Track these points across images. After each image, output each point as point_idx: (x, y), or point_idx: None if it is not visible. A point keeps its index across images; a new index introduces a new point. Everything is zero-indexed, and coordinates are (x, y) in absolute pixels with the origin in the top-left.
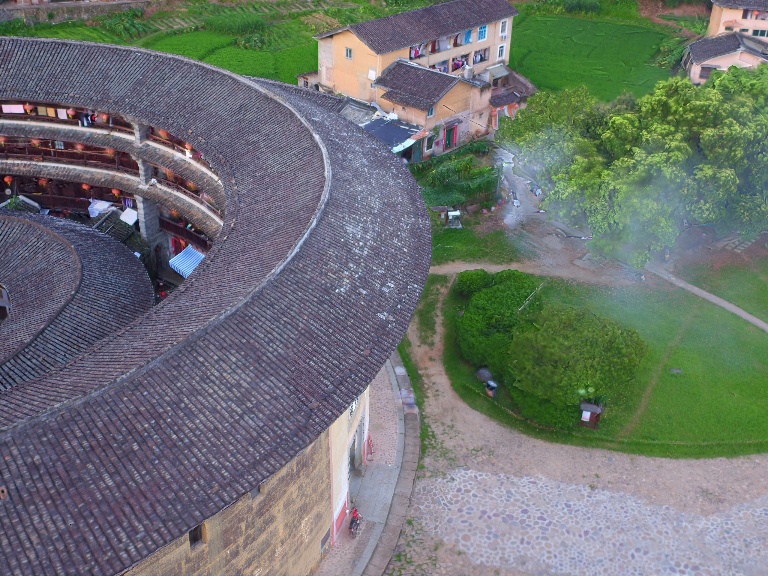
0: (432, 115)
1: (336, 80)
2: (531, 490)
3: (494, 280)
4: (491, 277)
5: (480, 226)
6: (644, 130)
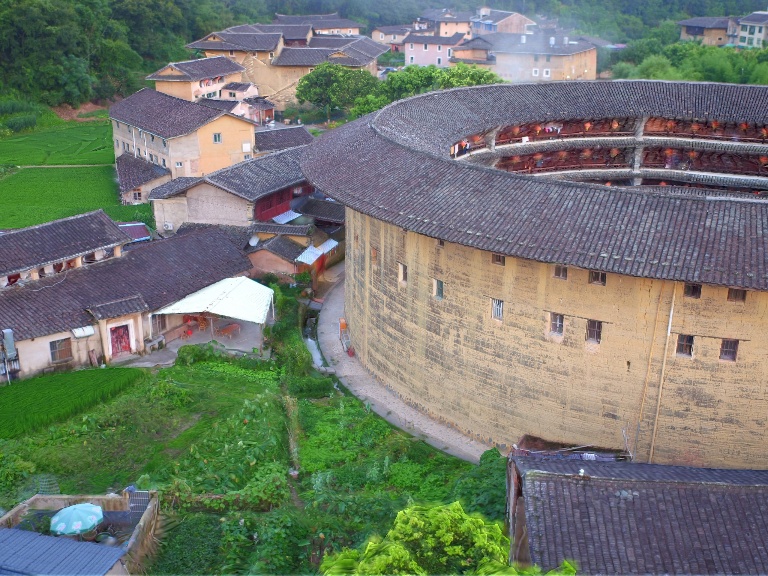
0: None
1: (205, 168)
2: None
3: None
4: None
5: None
6: None
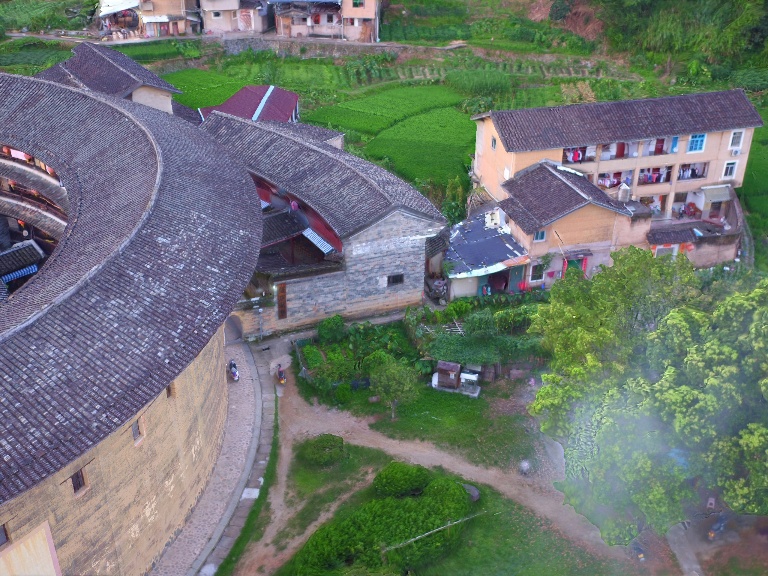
0: (543, 239)
1: (483, 170)
2: None
3: (423, 488)
4: (427, 482)
5: (505, 401)
6: (695, 345)
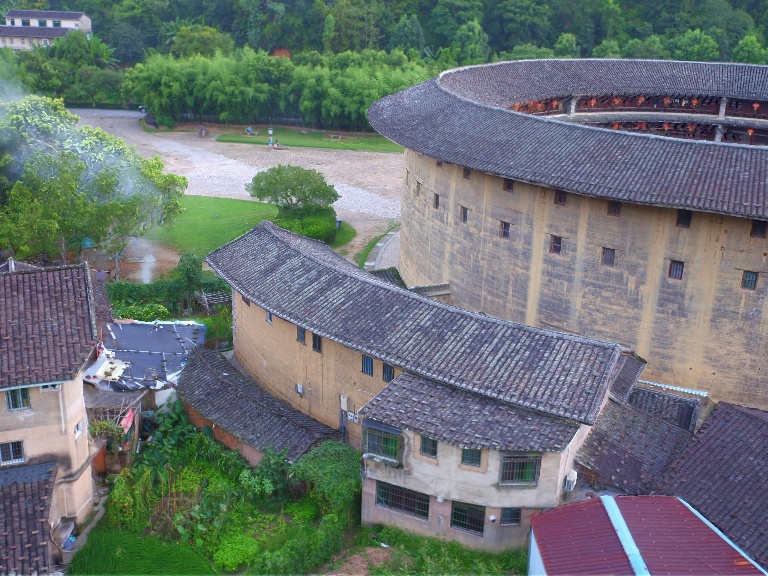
0: None
1: None
2: None
3: None
4: None
5: None
6: None
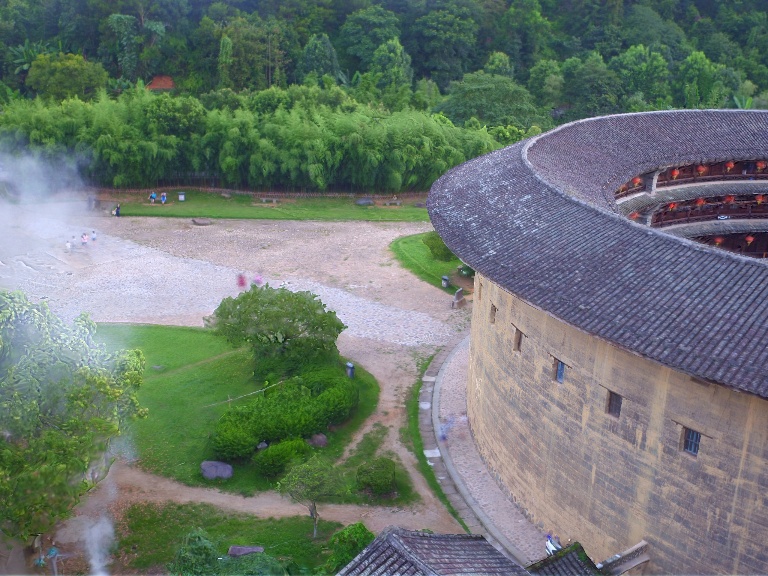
0: None
1: None
2: (365, 331)
3: None
4: (257, 452)
5: None
6: None
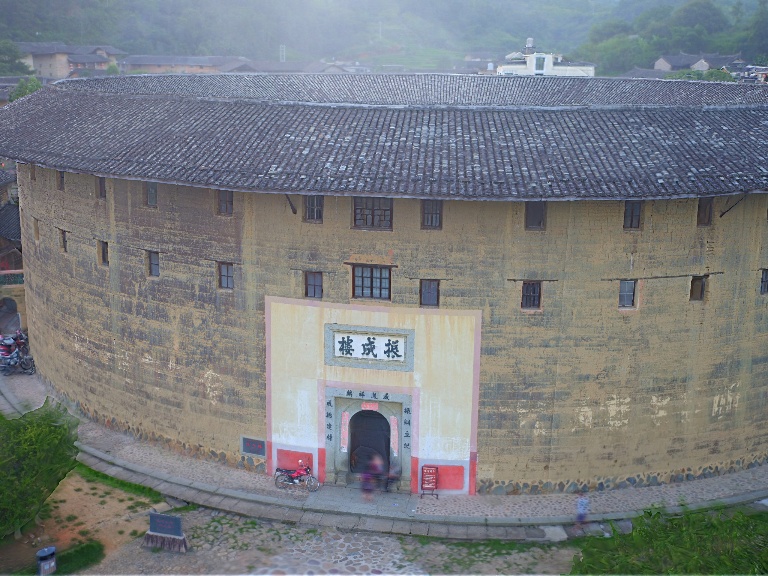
0: None
1: None
2: None
3: None
4: None
5: None
6: None
